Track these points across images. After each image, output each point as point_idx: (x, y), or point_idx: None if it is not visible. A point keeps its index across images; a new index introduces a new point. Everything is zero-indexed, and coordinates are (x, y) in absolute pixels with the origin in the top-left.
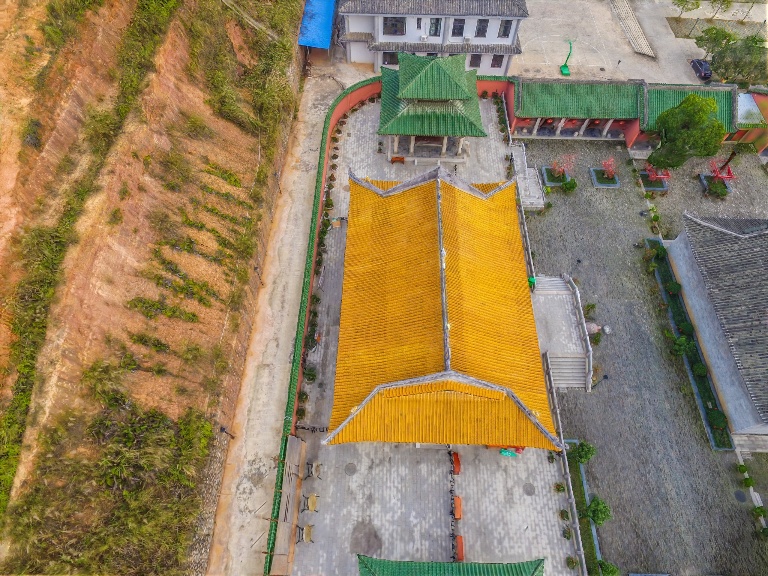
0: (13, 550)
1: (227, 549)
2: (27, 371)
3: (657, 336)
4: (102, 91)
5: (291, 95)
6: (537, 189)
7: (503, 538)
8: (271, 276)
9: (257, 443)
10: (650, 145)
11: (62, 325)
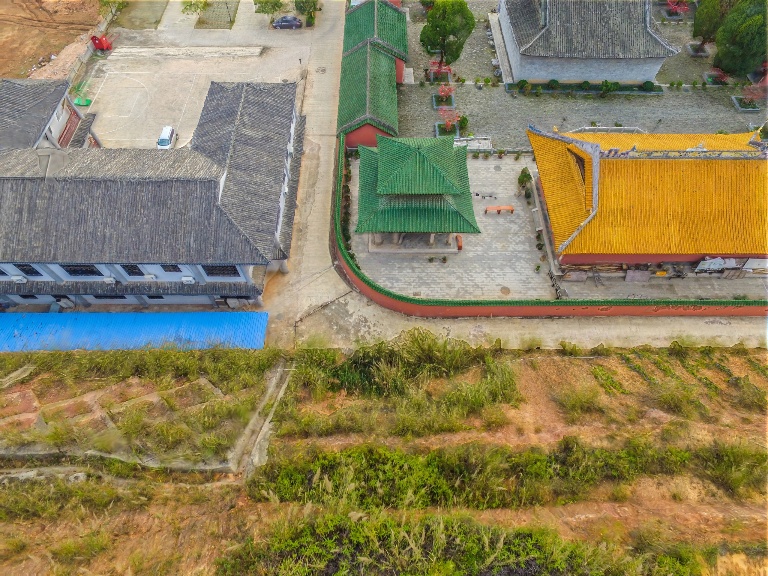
0: None
1: None
2: None
3: (592, 102)
4: (658, 501)
5: None
6: None
7: None
8: None
9: None
10: None
11: None
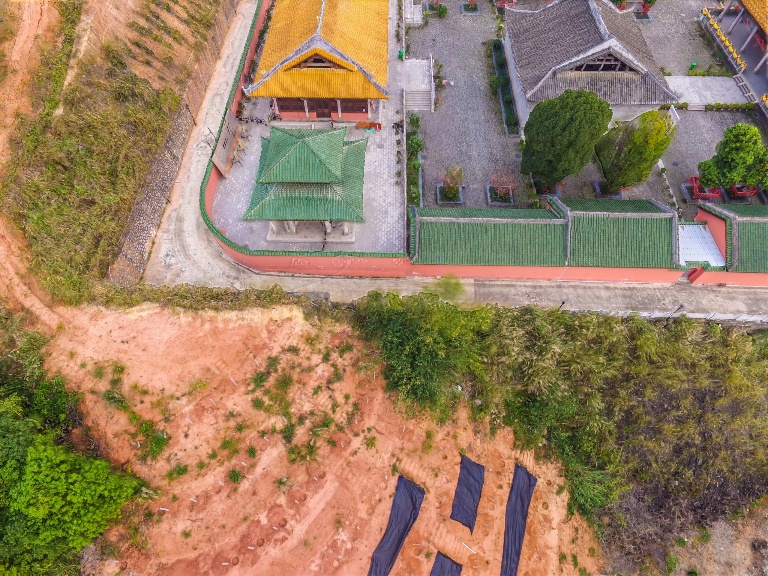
0: (65, 111)
1: (189, 170)
2: (70, 33)
3: (486, 87)
4: None
5: None
6: (420, 14)
7: None
8: (226, 54)
9: (211, 127)
10: None
11: (90, 14)
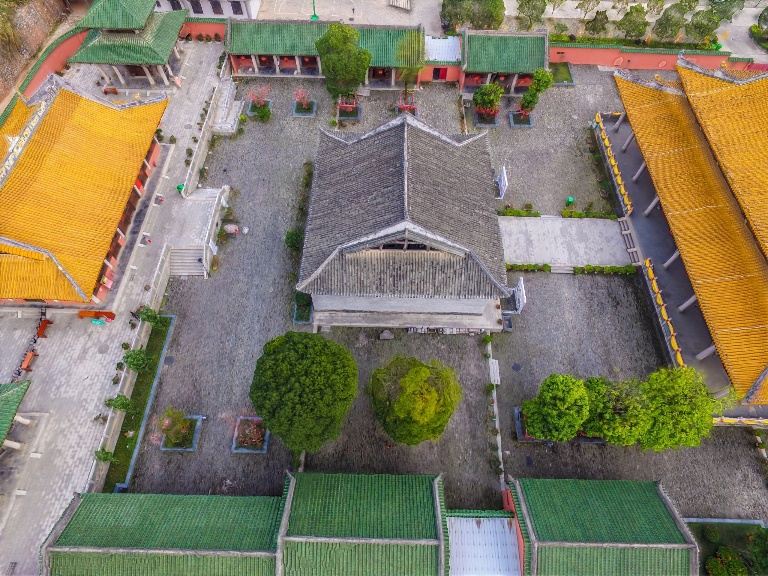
0: None
1: None
2: None
3: None
4: None
5: (4, 30)
6: None
7: (62, 385)
8: None
9: None
10: (361, 82)
11: None
